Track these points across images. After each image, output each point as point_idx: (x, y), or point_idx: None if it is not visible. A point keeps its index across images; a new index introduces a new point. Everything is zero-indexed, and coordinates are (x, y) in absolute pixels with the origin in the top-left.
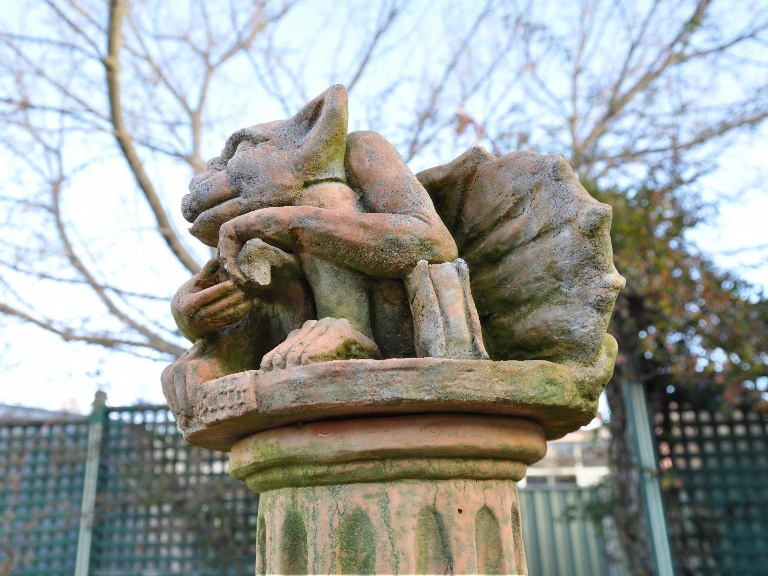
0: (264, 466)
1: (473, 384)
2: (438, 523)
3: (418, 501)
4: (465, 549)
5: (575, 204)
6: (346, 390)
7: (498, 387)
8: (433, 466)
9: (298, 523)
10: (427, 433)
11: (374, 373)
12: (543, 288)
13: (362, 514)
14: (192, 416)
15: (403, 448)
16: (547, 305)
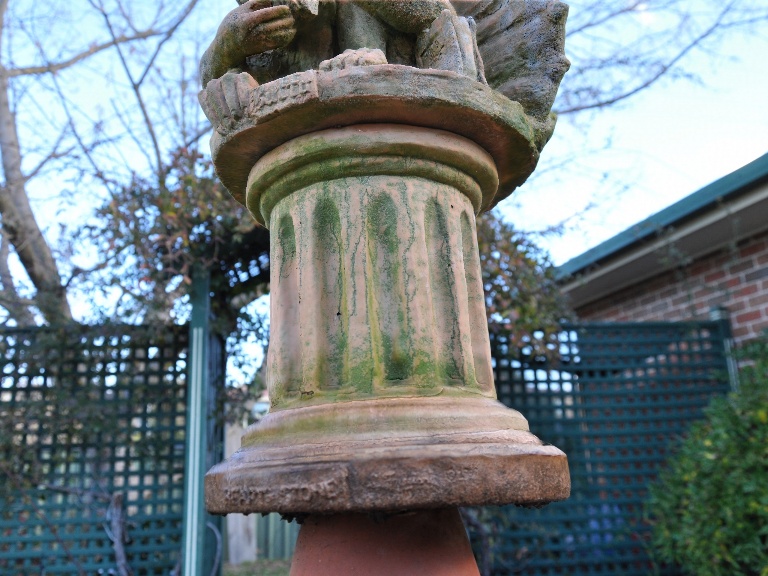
0: (303, 161)
1: (482, 100)
2: (438, 212)
3: (426, 192)
4: (456, 231)
5: None
6: (395, 87)
7: (496, 107)
8: (439, 168)
9: (327, 209)
10: (440, 138)
11: (417, 76)
12: (511, 65)
13: (386, 196)
14: (241, 117)
15: (424, 145)
16: (513, 78)
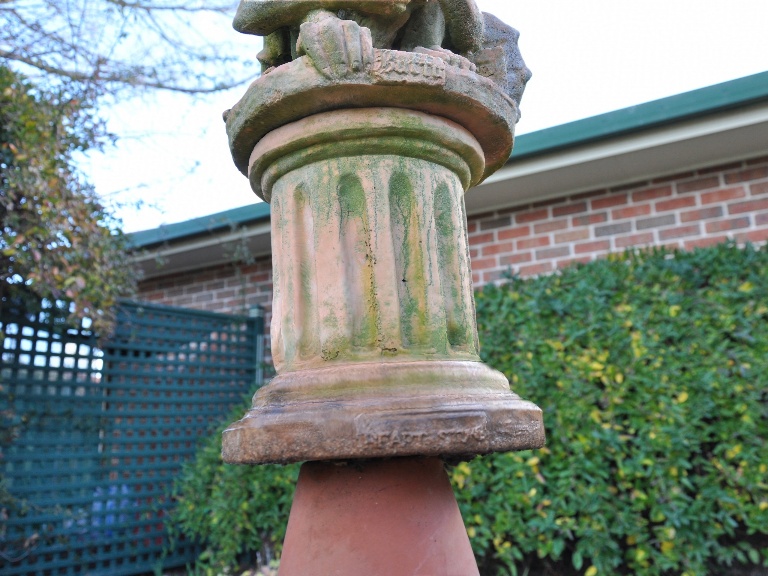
0: (394, 132)
1: None
2: None
3: None
4: None
5: (522, 61)
6: None
7: None
8: None
9: (398, 182)
10: None
11: None
12: None
13: (445, 185)
14: (360, 70)
15: None
16: None
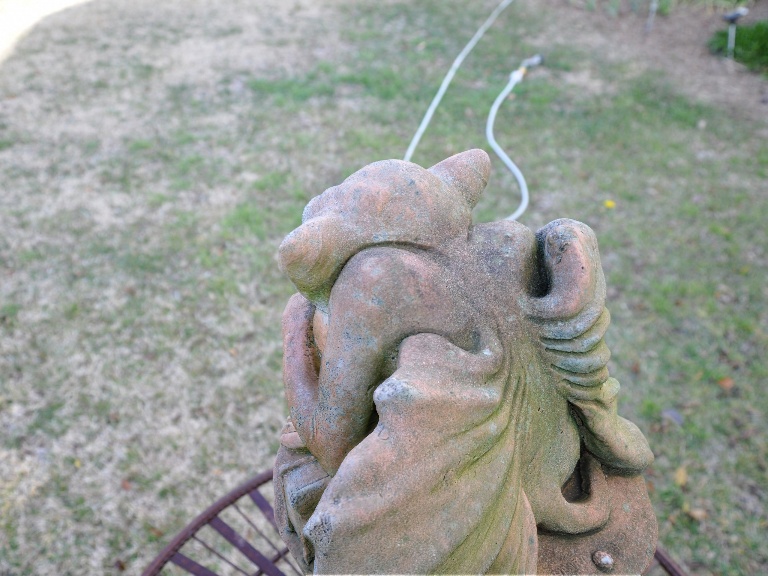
0: None
1: None
2: None
3: None
4: None
5: None
6: None
7: None
8: None
9: None
10: None
11: None
12: None
13: None
14: None
15: None
16: None
